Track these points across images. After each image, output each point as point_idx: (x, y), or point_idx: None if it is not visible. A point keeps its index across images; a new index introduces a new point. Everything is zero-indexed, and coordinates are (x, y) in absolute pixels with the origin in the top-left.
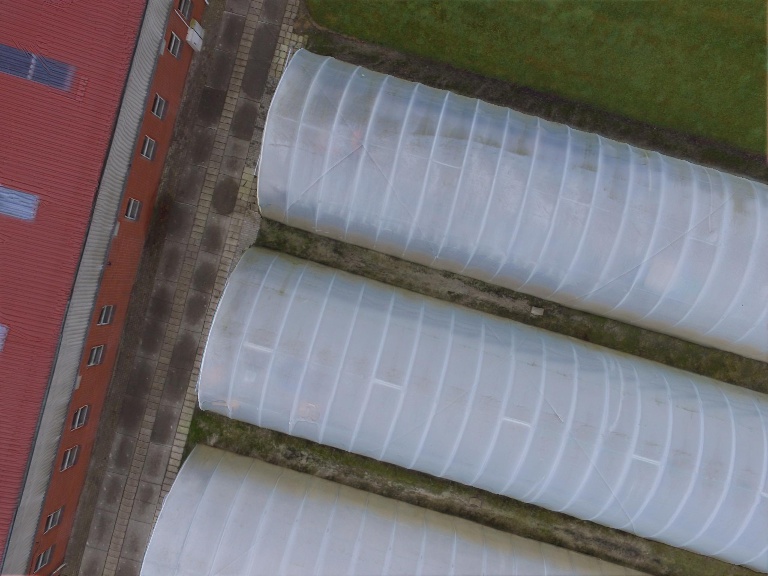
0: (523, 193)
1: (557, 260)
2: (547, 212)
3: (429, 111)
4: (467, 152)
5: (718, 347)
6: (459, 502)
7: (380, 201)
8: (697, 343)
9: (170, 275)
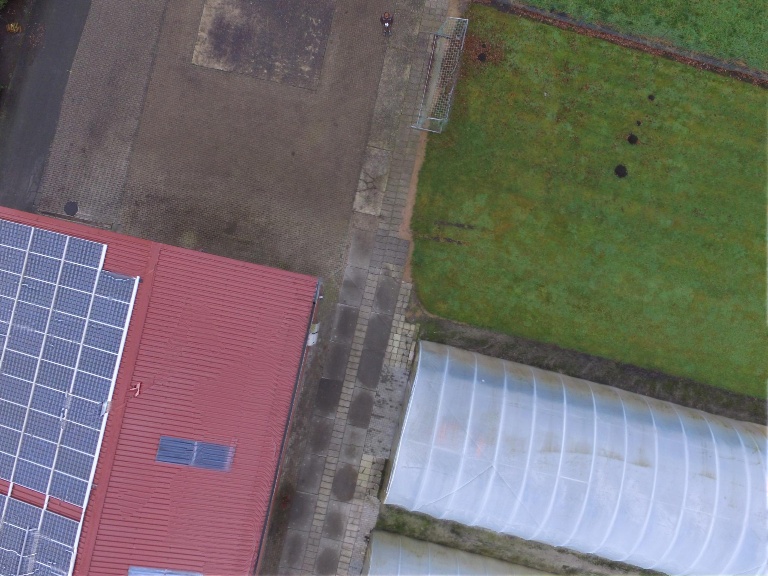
0: (648, 506)
1: (679, 560)
2: (671, 522)
3: (552, 423)
4: (592, 467)
5: None
6: None
7: (508, 512)
8: None
9: (294, 562)
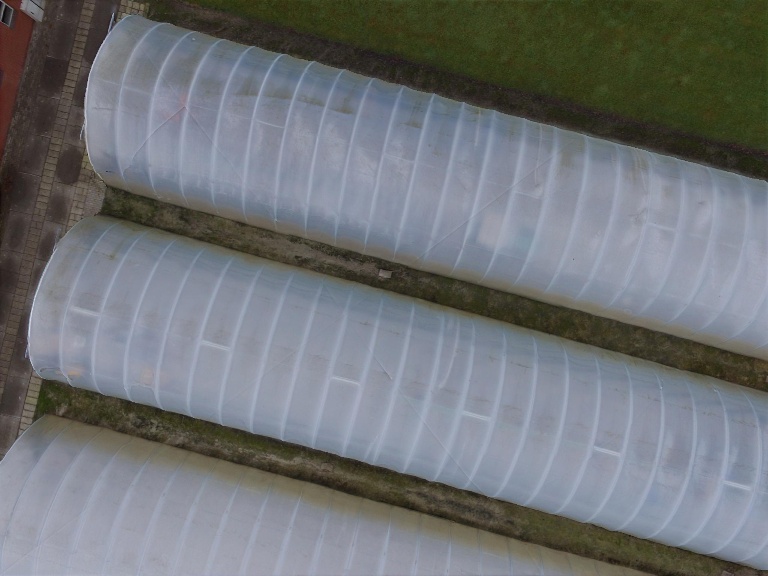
0: (346, 151)
1: (387, 218)
2: (372, 169)
3: (255, 72)
4: (290, 111)
5: (566, 305)
6: (311, 467)
7: (207, 163)
8: (546, 302)
9: (15, 246)
